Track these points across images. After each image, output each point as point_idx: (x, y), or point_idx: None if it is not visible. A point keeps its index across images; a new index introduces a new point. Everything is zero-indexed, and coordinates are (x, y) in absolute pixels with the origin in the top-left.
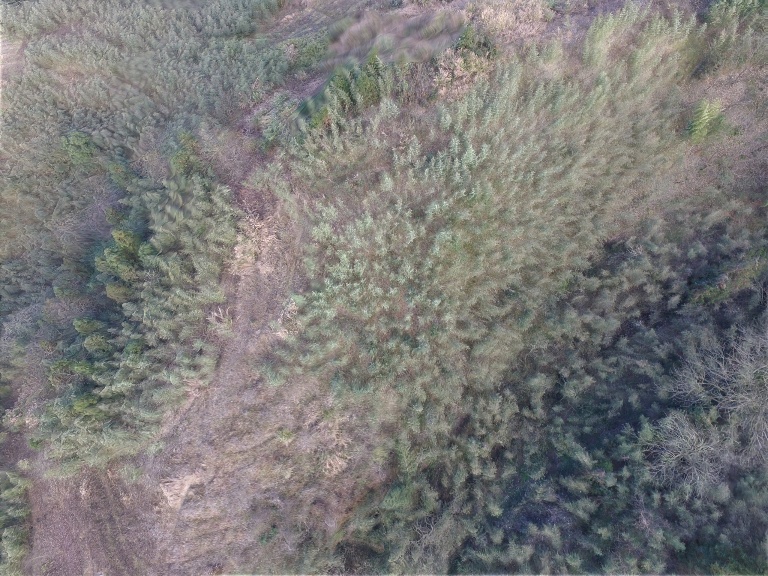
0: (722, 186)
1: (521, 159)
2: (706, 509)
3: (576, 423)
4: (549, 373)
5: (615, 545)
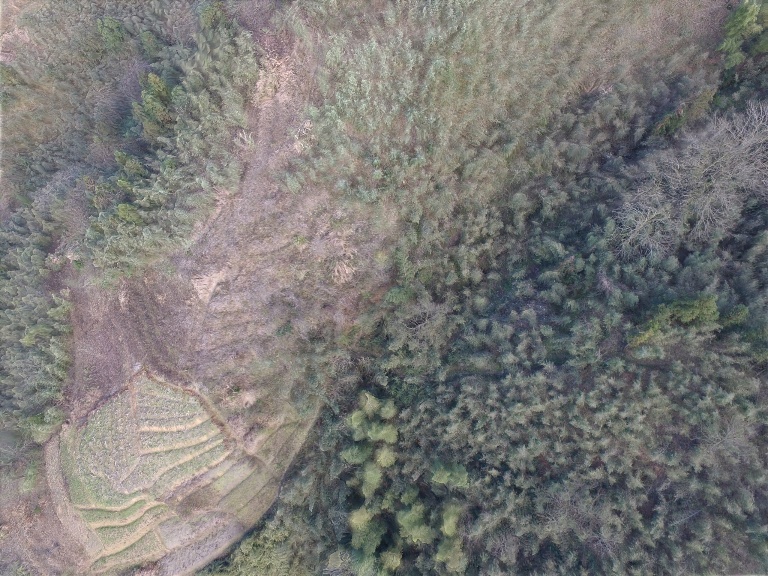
0: (683, 34)
1: (507, 4)
2: (658, 275)
3: (553, 235)
4: (530, 197)
5: (582, 312)
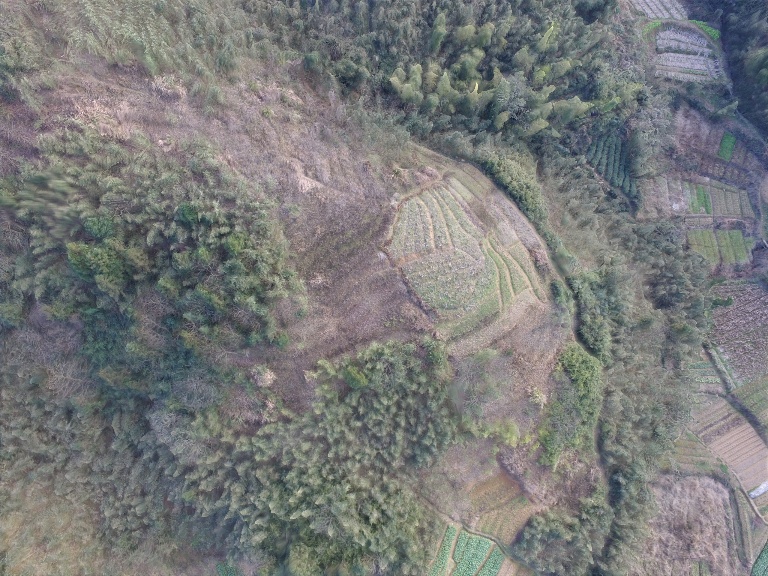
0: None
1: None
2: None
3: None
4: None
5: None
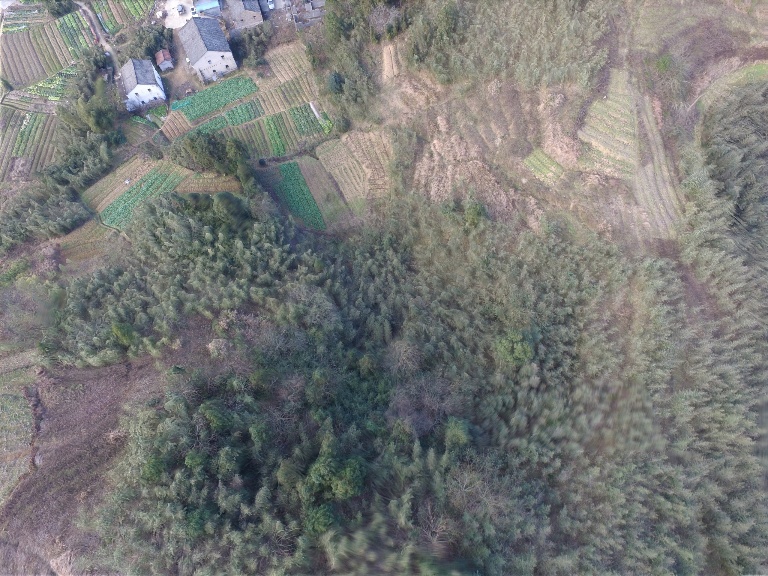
0: None
1: None
2: None
3: None
4: None
5: None
